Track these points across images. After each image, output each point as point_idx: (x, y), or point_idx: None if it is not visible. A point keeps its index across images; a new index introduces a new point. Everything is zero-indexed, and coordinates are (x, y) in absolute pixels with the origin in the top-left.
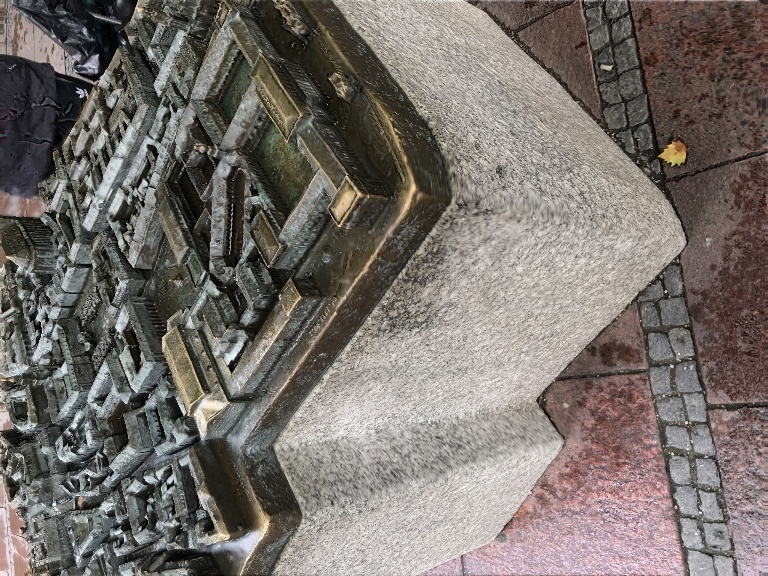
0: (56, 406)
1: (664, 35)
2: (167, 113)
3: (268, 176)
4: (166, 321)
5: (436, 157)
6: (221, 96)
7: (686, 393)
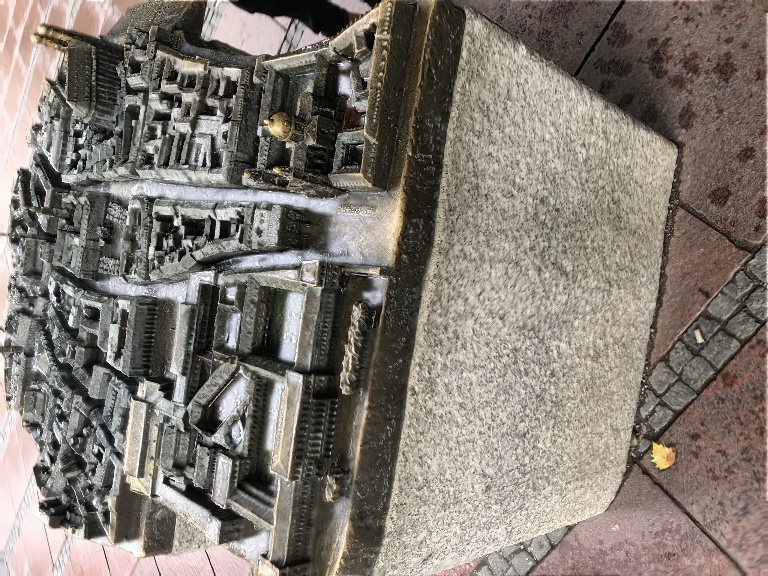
0: (61, 251)
1: (759, 377)
2: (238, 218)
3: (265, 407)
4: (157, 334)
5: (367, 570)
6: (278, 290)
7: (514, 568)
